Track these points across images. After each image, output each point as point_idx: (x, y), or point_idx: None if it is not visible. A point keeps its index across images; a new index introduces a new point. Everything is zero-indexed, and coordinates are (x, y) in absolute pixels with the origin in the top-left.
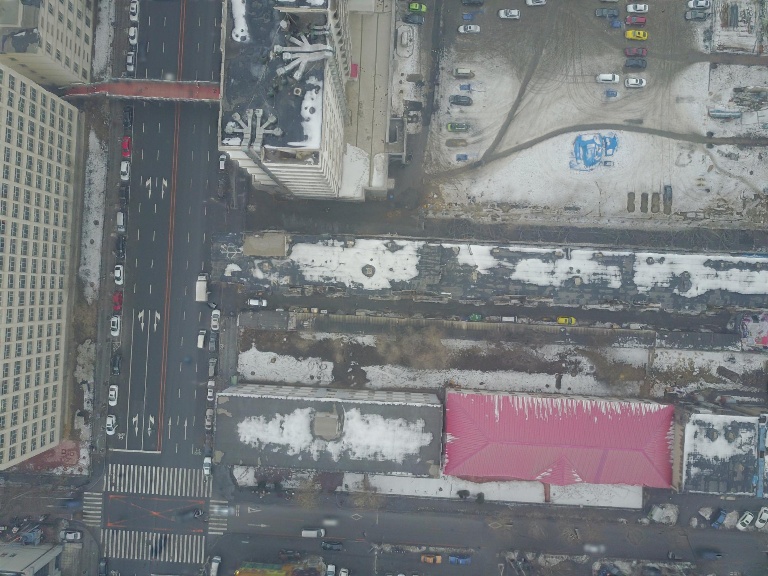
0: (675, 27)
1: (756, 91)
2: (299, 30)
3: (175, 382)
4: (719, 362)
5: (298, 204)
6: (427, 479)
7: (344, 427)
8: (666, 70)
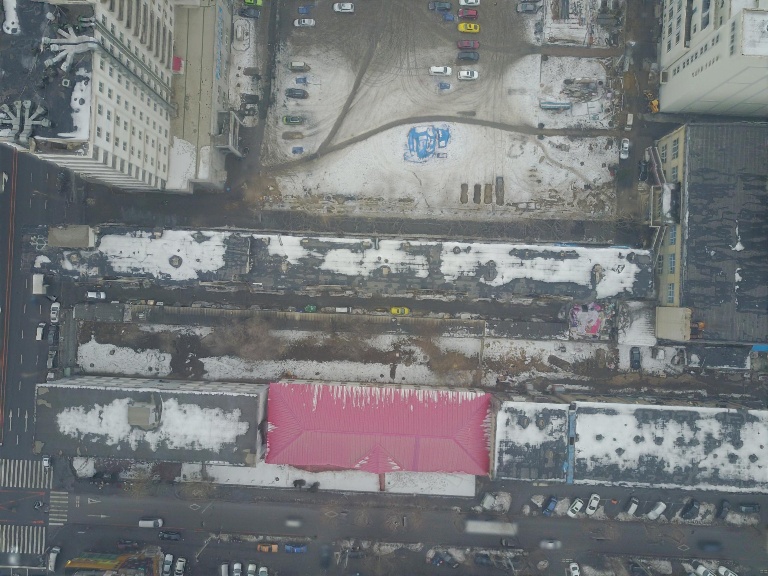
0: (507, 20)
1: (585, 83)
2: (68, 22)
3: (16, 374)
4: (550, 351)
5: (136, 197)
6: (263, 469)
7: (162, 417)
8: (498, 62)
